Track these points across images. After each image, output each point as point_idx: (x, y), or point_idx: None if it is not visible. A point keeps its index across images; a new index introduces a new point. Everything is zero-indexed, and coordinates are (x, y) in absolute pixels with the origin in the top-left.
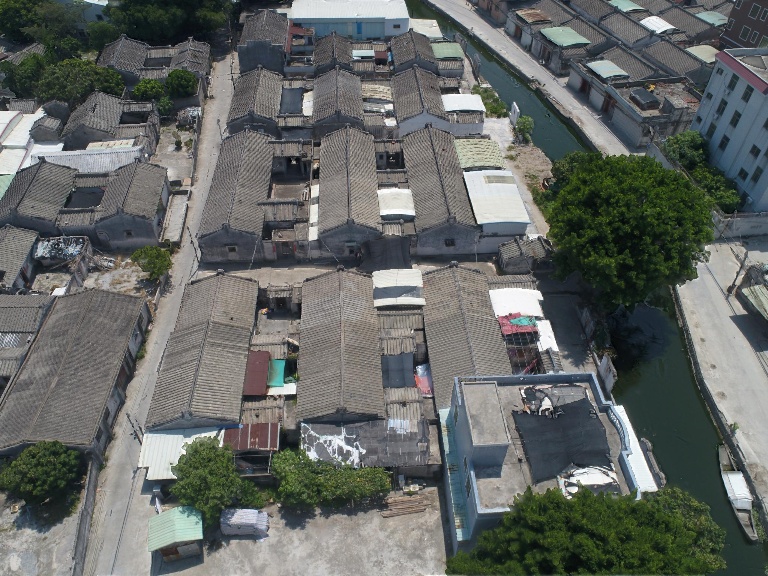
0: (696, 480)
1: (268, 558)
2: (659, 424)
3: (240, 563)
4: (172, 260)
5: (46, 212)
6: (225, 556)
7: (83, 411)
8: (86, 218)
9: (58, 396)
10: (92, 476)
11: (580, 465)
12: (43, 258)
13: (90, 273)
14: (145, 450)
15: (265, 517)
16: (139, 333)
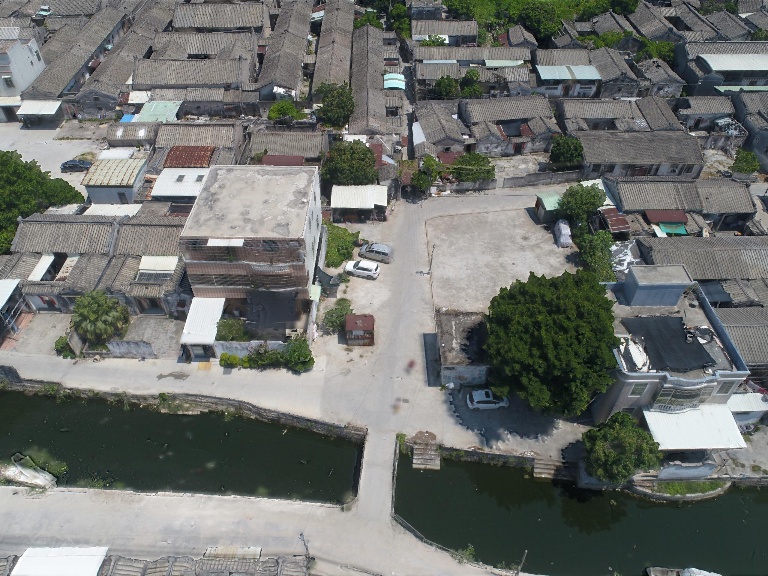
0: (702, 548)
1: (546, 249)
2: (763, 532)
3: (540, 238)
4: (760, 182)
5: (753, 106)
6: (543, 232)
7: (606, 155)
8: (762, 124)
9: (611, 143)
10: (572, 175)
11: (646, 349)
12: (717, 124)
13: (721, 150)
14: (591, 182)
15: (568, 241)
16: (678, 173)
